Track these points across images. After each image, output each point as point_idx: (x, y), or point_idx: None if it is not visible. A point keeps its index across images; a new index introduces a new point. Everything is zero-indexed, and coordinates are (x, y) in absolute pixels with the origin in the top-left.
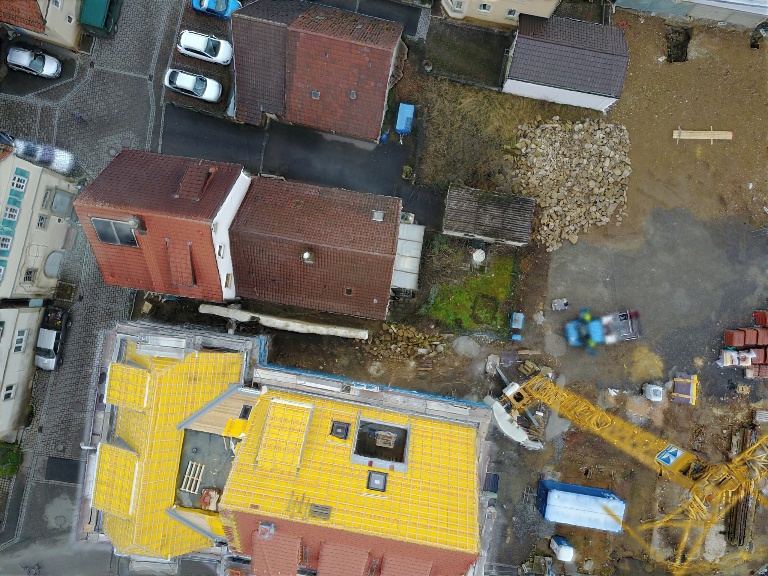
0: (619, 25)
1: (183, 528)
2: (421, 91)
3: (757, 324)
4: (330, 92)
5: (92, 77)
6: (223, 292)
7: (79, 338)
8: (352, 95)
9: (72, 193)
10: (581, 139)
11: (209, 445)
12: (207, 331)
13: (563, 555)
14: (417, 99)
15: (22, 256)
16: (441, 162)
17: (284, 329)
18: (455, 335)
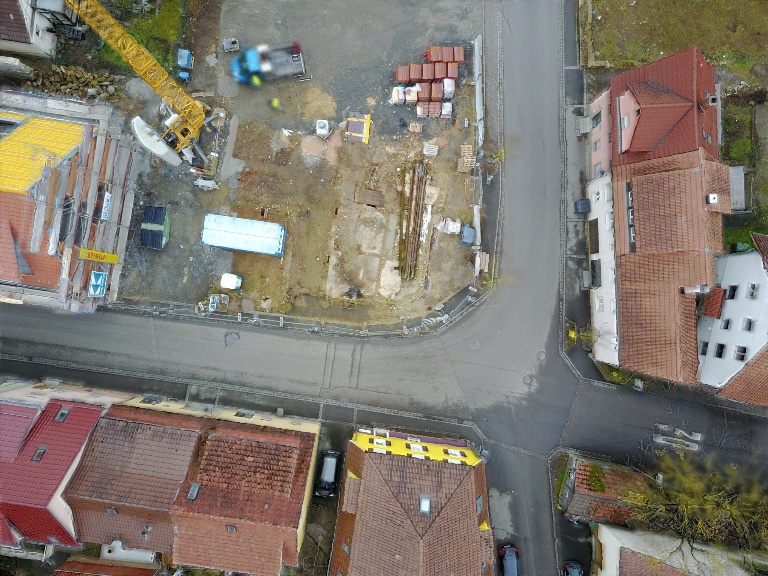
0: None
1: None
2: None
3: None
4: None
5: None
6: None
7: None
8: None
9: None
10: None
11: None
12: None
13: (226, 282)
14: None
15: None
16: None
17: None
18: (127, 77)
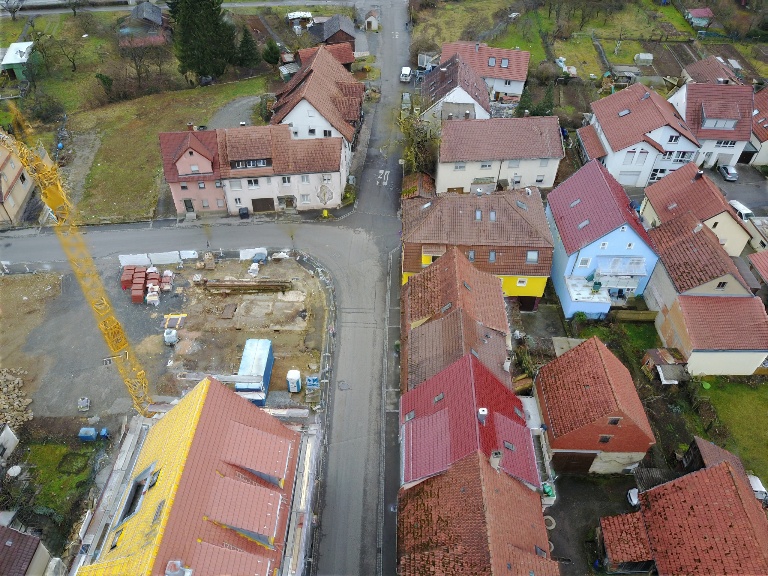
0: None
1: None
2: None
3: None
4: None
5: None
6: None
7: None
8: None
9: None
10: None
11: None
12: None
13: (294, 376)
14: None
15: None
16: None
17: None
18: (93, 487)
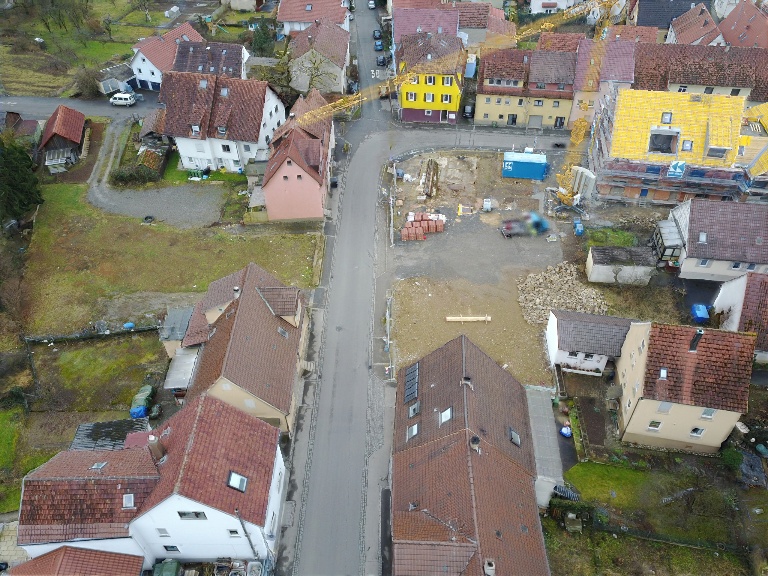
0: None
1: None
2: None
3: (423, 234)
4: None
5: None
6: None
7: None
8: None
9: None
10: None
11: None
12: None
13: None
14: None
15: None
16: None
17: None
18: None
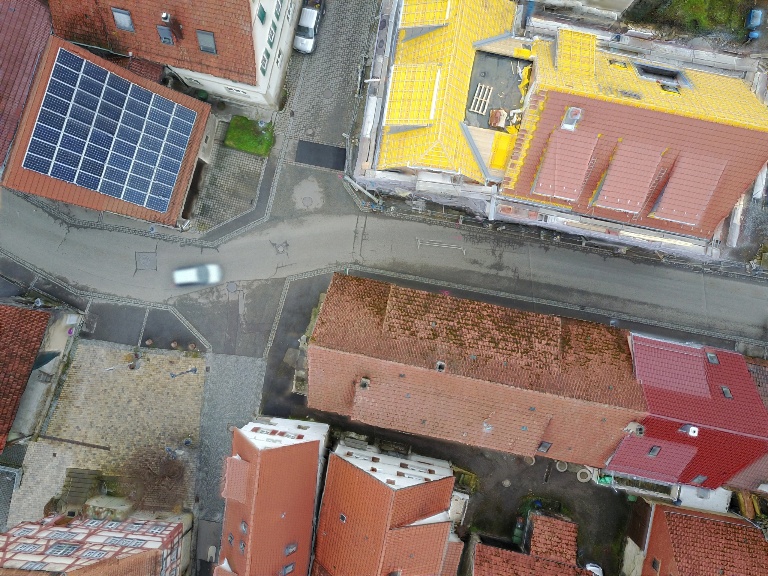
0: None
1: (468, 151)
2: None
3: None
4: None
5: None
6: None
7: (331, 28)
8: None
9: None
10: None
11: (497, 69)
12: None
13: None
14: None
15: None
16: None
17: (541, 3)
18: (689, 37)
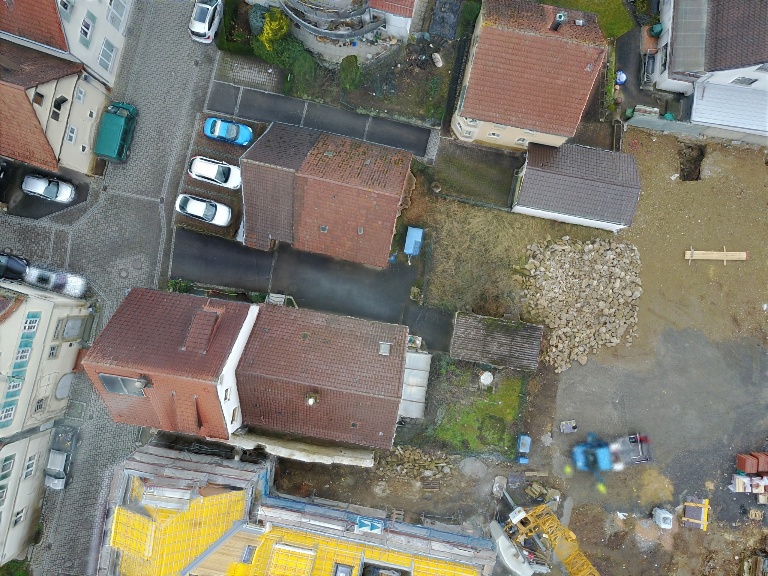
0: (630, 143)
1: None
2: (430, 211)
3: None
4: (338, 227)
5: (105, 200)
6: (229, 432)
7: (89, 456)
8: (359, 231)
9: (84, 315)
10: (591, 260)
11: None
12: (214, 457)
13: None
14: (426, 220)
15: (33, 389)
16: (449, 282)
17: None
18: (462, 456)
